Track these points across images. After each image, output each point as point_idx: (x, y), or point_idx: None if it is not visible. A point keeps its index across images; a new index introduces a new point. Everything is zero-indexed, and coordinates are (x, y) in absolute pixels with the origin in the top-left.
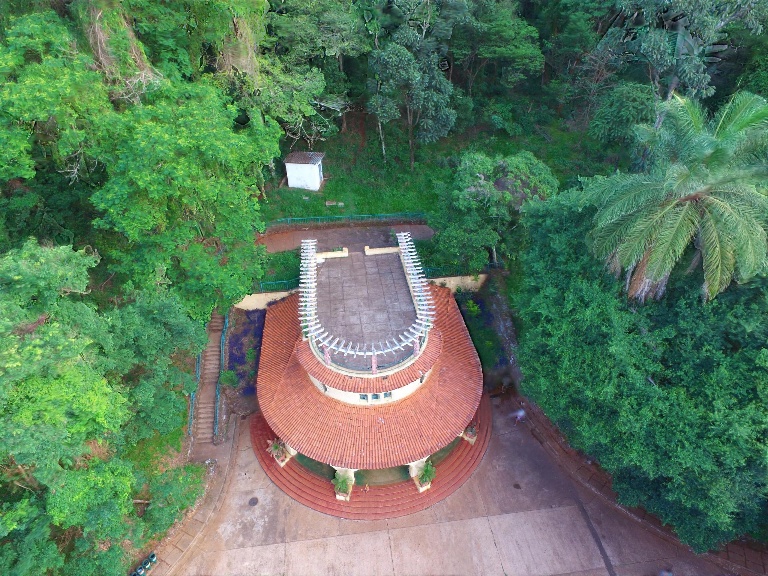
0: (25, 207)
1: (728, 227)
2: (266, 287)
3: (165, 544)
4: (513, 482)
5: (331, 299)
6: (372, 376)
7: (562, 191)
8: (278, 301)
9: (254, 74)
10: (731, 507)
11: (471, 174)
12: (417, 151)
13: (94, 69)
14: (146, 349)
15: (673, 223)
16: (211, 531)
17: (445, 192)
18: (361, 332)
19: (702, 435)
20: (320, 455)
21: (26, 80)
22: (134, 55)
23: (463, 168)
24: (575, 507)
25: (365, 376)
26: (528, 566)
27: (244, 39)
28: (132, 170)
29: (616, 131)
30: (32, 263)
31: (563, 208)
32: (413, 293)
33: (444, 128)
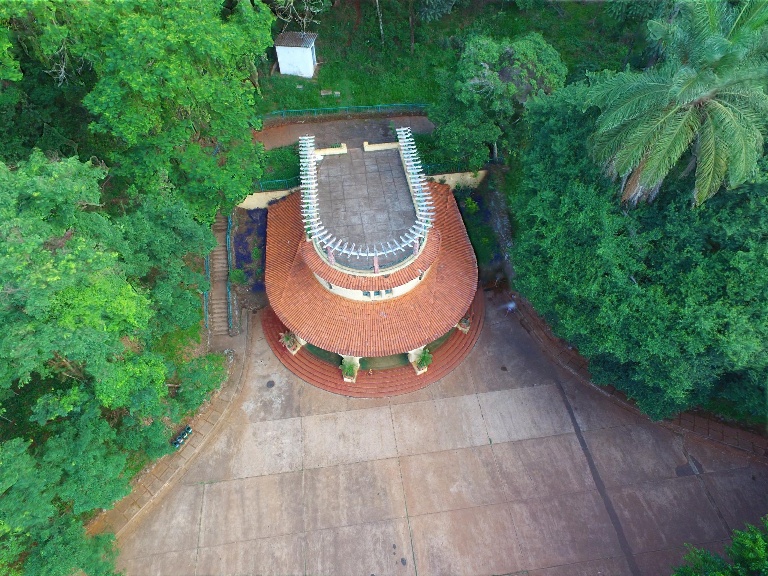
0: (9, 104)
1: (725, 135)
2: (266, 186)
3: (197, 419)
4: (501, 365)
5: (332, 199)
6: (374, 275)
7: (570, 78)
8: (279, 200)
9: None
10: (687, 386)
11: (475, 62)
12: (417, 29)
13: None
14: (159, 253)
15: (673, 129)
16: (236, 408)
17: (447, 81)
18: (362, 232)
19: (671, 327)
20: (328, 345)
21: None
22: None
23: (467, 55)
24: (554, 385)
25: (368, 275)
26: (509, 432)
27: None
28: (122, 70)
29: (635, 8)
30: (47, 179)
31: (568, 106)
32: (413, 192)
33: (448, 3)
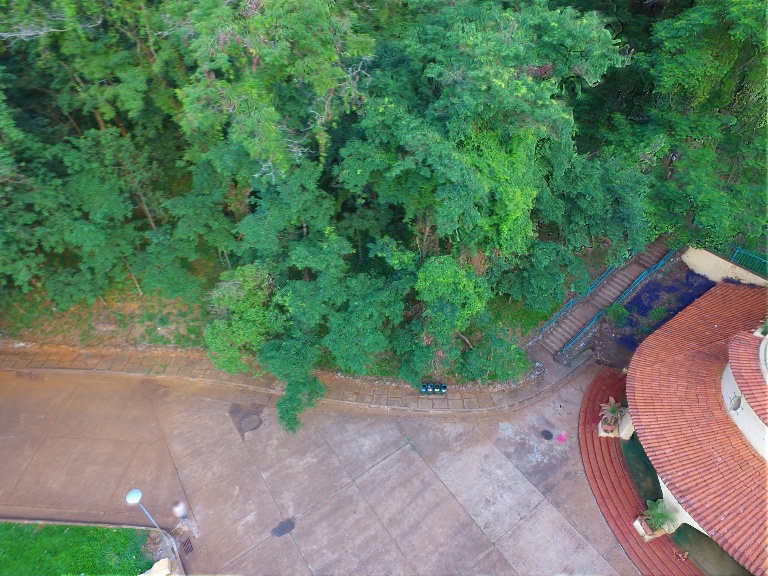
0: None
1: None
2: (741, 259)
3: (458, 389)
4: None
5: None
6: None
7: None
8: (742, 284)
9: None
10: None
11: None
12: None
13: None
14: (577, 215)
15: None
16: (495, 418)
17: None
18: None
19: None
20: (661, 463)
21: None
22: None
23: None
24: None
25: None
26: None
27: None
28: None
29: None
30: (576, 15)
31: None
32: None
33: None
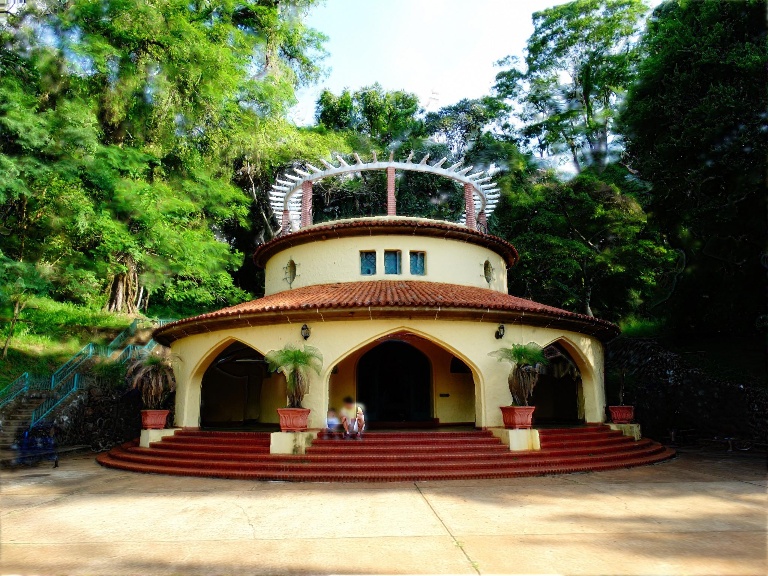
0: None
1: None
2: None
3: None
4: None
5: None
6: (387, 217)
7: None
8: None
9: None
10: None
11: None
12: None
13: None
14: None
15: None
16: None
17: None
18: None
19: None
20: None
21: None
22: None
23: None
24: None
25: None
26: None
27: (273, 71)
28: None
29: None
30: None
31: None
32: None
33: None
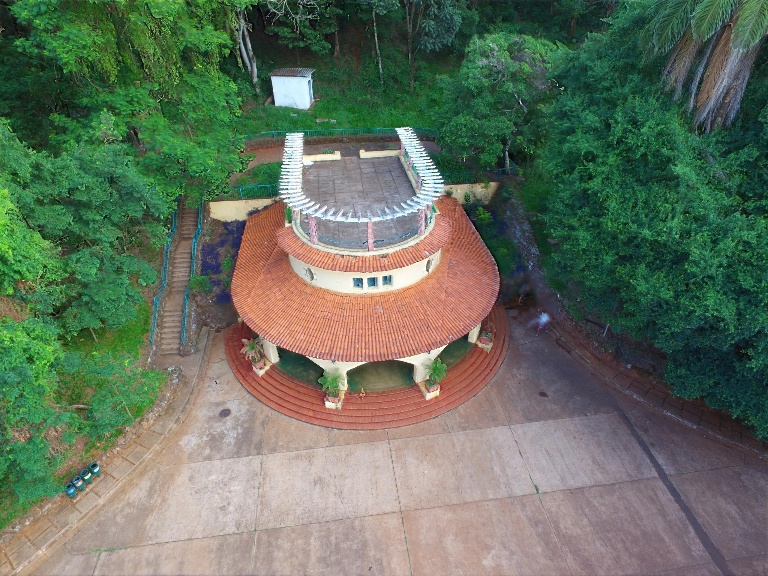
0: None
1: None
2: (246, 194)
3: (112, 456)
4: (538, 390)
5: (320, 193)
6: (368, 253)
7: None
8: (260, 210)
9: None
10: None
11: (481, 55)
12: (417, 72)
13: None
14: (88, 212)
15: None
16: (171, 443)
17: (451, 86)
18: None
19: None
20: (305, 348)
21: None
22: None
23: (472, 49)
24: (615, 415)
25: (359, 253)
26: (562, 476)
27: None
28: None
29: None
30: None
31: (600, 41)
32: None
33: (448, 34)
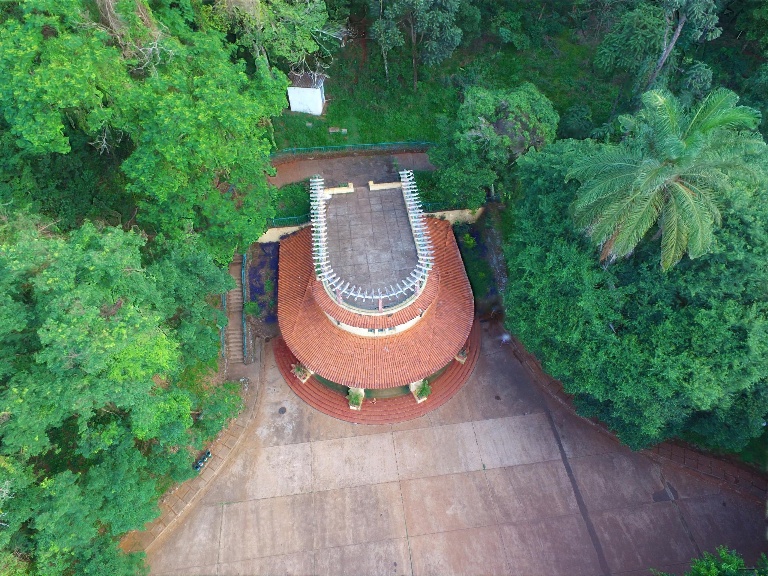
0: None
1: (684, 217)
2: (278, 222)
3: (216, 444)
4: (495, 394)
5: (340, 238)
6: (379, 314)
7: (563, 120)
8: (290, 235)
9: (256, 12)
10: (659, 424)
11: (473, 113)
12: (420, 68)
13: (111, 44)
14: (184, 295)
15: (641, 208)
16: (251, 433)
17: (447, 127)
18: (368, 272)
19: (644, 373)
20: (336, 377)
21: (49, 58)
22: (141, 13)
23: (465, 106)
24: (543, 414)
25: (373, 314)
26: (501, 458)
27: None
28: (158, 143)
29: (622, 61)
30: (101, 255)
31: None
32: None
33: (449, 49)
